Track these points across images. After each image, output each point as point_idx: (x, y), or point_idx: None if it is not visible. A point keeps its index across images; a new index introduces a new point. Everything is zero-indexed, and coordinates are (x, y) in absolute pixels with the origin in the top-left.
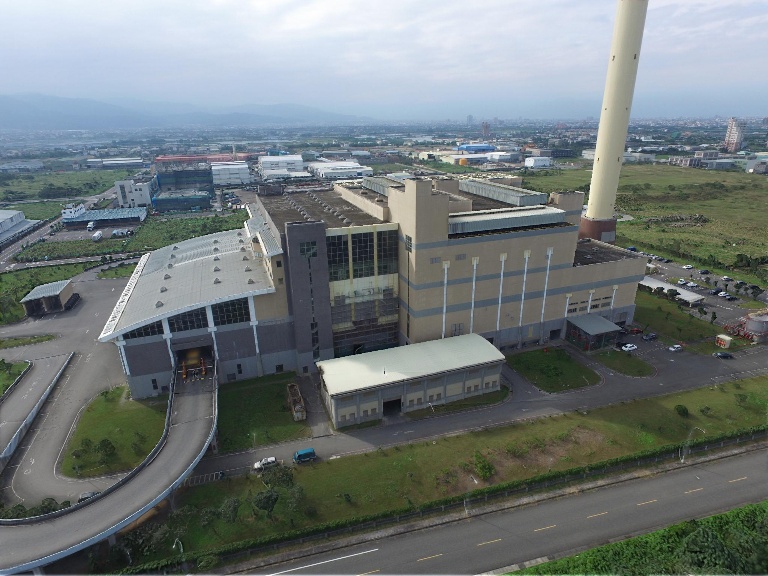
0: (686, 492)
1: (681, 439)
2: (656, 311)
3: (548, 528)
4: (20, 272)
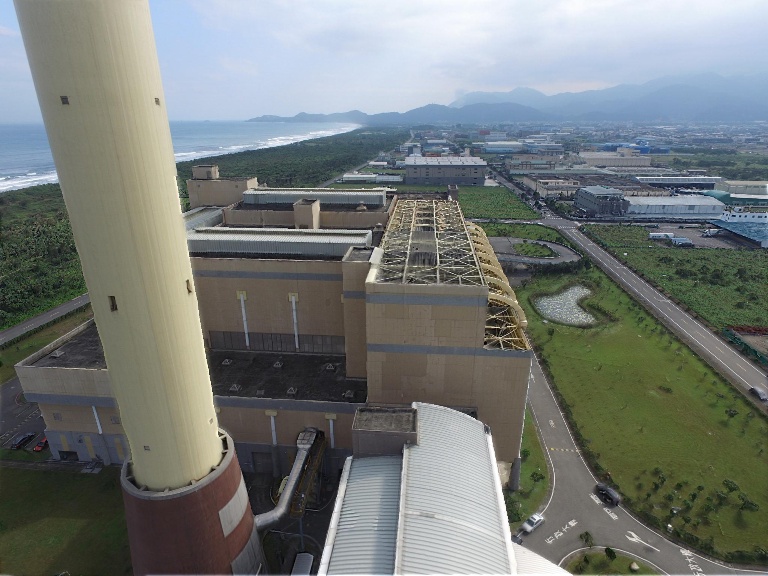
0: (4, 338)
1: (1, 356)
2: (7, 521)
3: (76, 303)
4: (546, 229)
